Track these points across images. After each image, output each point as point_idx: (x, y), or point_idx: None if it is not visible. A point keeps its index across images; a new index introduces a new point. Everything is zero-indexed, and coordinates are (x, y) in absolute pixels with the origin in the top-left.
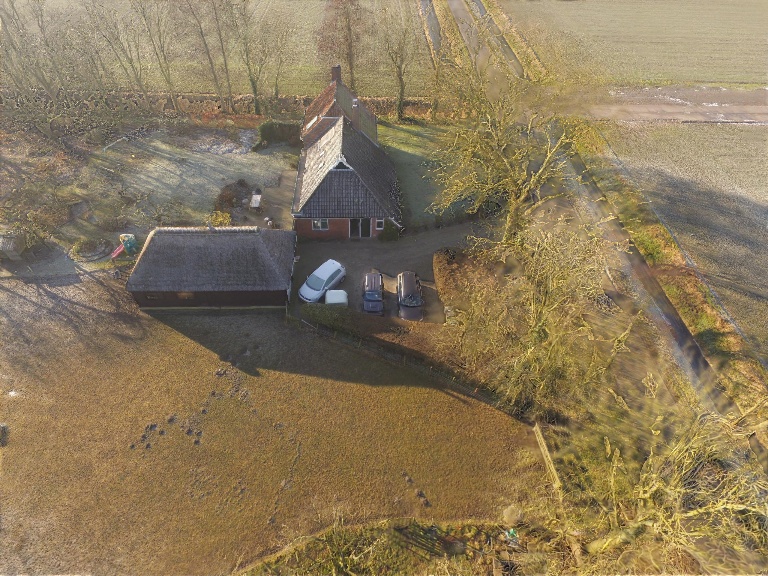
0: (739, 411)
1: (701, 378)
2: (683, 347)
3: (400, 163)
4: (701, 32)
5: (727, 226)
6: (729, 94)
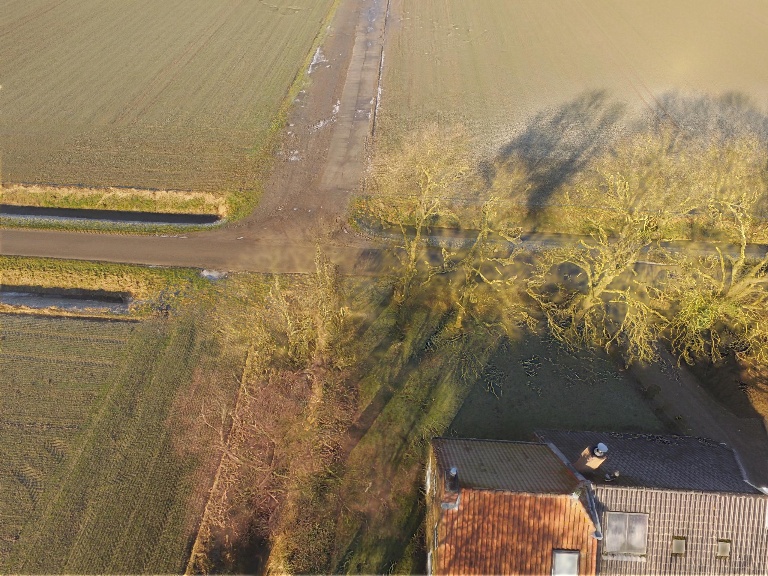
0: (759, 244)
1: (737, 252)
2: (708, 250)
3: (499, 425)
4: (155, 57)
5: (557, 173)
6: (317, 93)
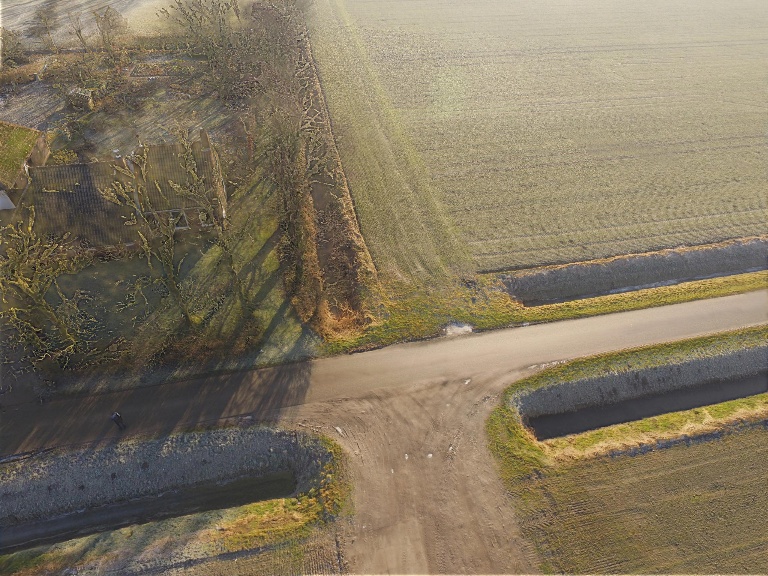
0: None
1: None
2: None
3: None
4: None
5: None
6: None
